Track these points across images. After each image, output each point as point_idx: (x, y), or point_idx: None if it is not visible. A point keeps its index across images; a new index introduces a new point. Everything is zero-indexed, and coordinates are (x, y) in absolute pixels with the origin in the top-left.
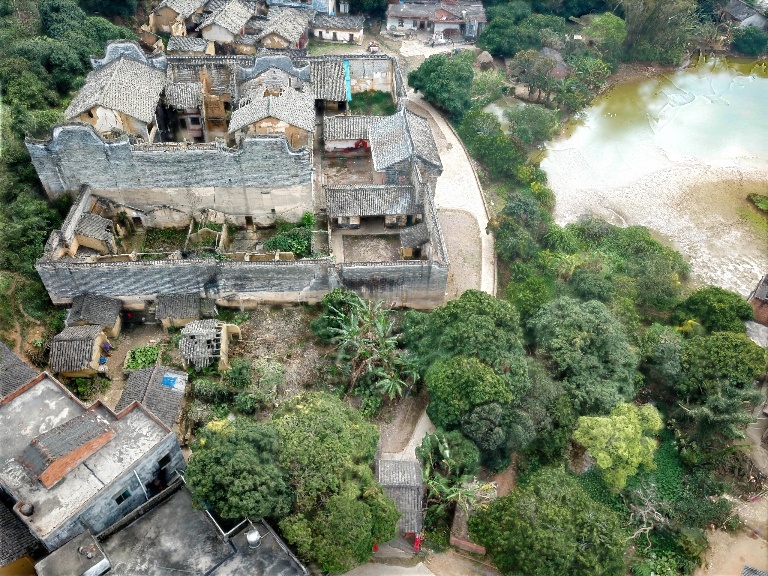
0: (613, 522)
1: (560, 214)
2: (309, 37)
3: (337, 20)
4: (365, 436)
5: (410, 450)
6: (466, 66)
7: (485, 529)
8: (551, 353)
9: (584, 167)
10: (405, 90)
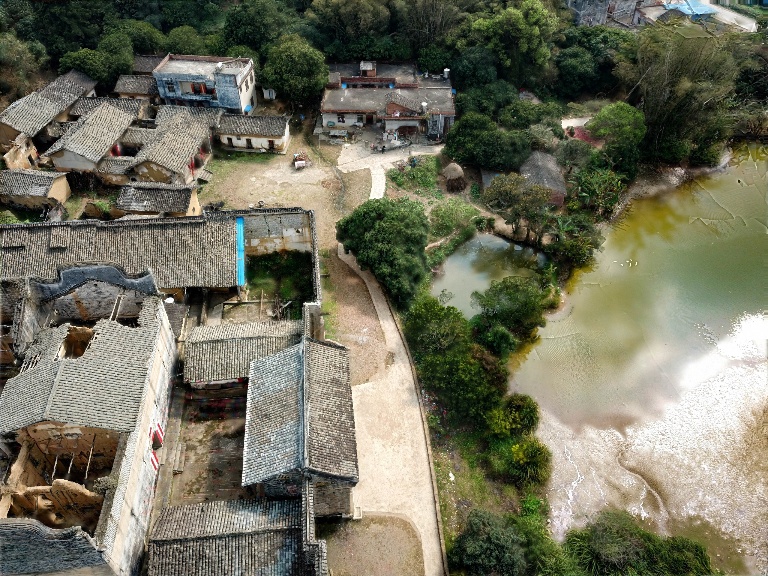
0: None
1: (559, 490)
2: (214, 145)
3: (250, 122)
4: None
5: None
6: (418, 216)
7: None
8: None
9: (594, 375)
10: (316, 285)
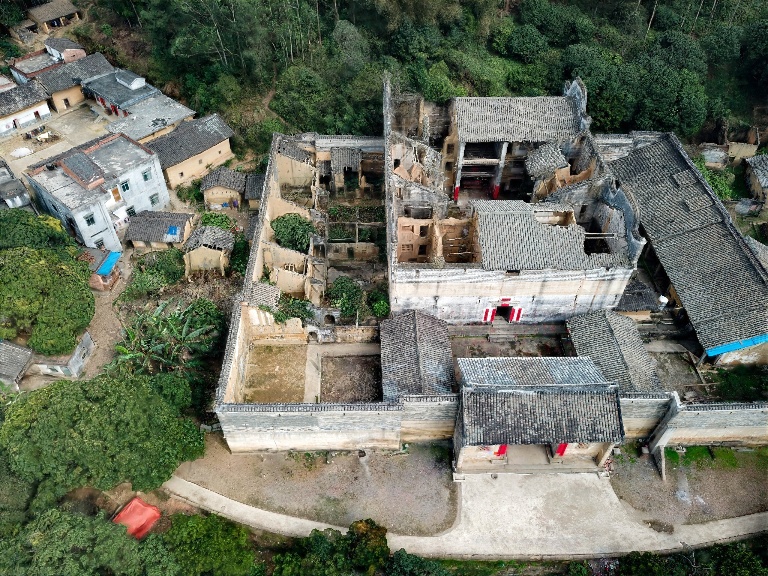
0: None
1: None
2: None
3: None
4: (7, 310)
5: None
6: None
7: None
8: None
9: None
10: (710, 403)
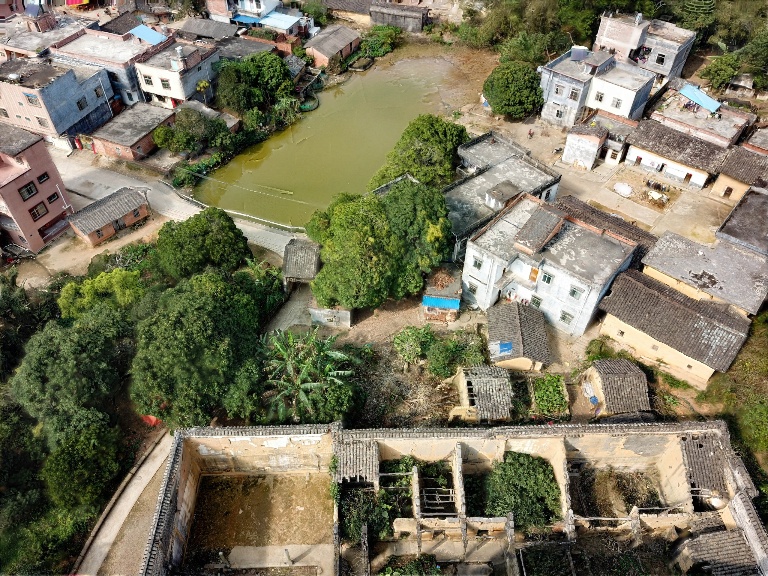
0: (161, 231)
1: None
2: None
3: None
4: None
5: (283, 327)
6: None
7: (246, 253)
8: (121, 333)
9: None
10: None
